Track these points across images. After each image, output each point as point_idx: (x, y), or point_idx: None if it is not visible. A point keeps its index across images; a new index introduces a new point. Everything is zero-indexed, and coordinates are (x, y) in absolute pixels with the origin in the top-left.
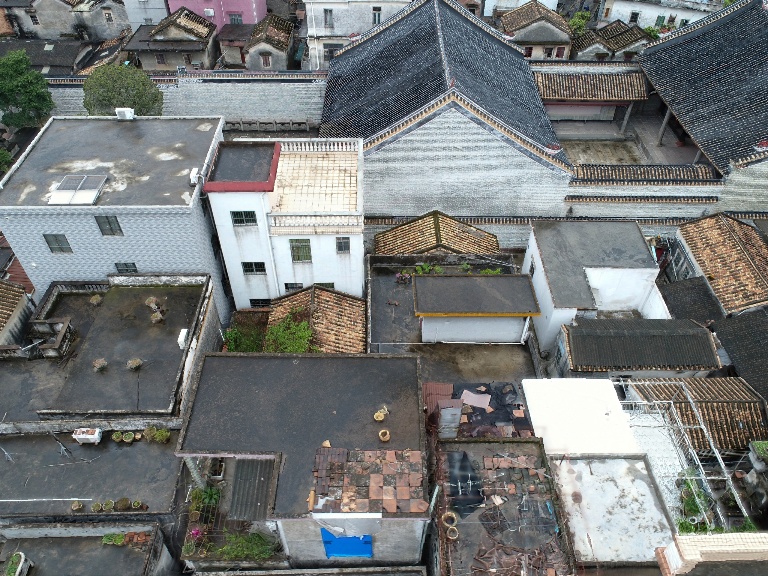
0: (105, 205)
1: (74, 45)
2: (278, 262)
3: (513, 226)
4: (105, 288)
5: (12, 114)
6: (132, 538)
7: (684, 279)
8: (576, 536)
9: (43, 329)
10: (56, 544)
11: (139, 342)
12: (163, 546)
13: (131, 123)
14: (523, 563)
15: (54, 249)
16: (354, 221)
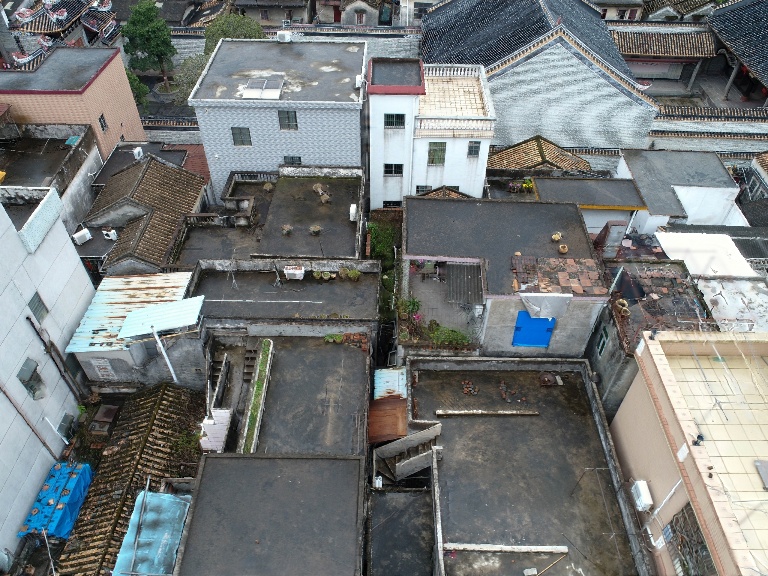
0: (289, 100)
1: (181, 3)
2: (415, 164)
3: (601, 157)
4: (274, 178)
5: (138, 59)
6: (348, 338)
7: (761, 199)
8: (717, 324)
9: (230, 206)
10: (288, 341)
11: (313, 216)
12: (371, 346)
13: (289, 45)
14: (697, 311)
15: (237, 142)
16: (488, 126)
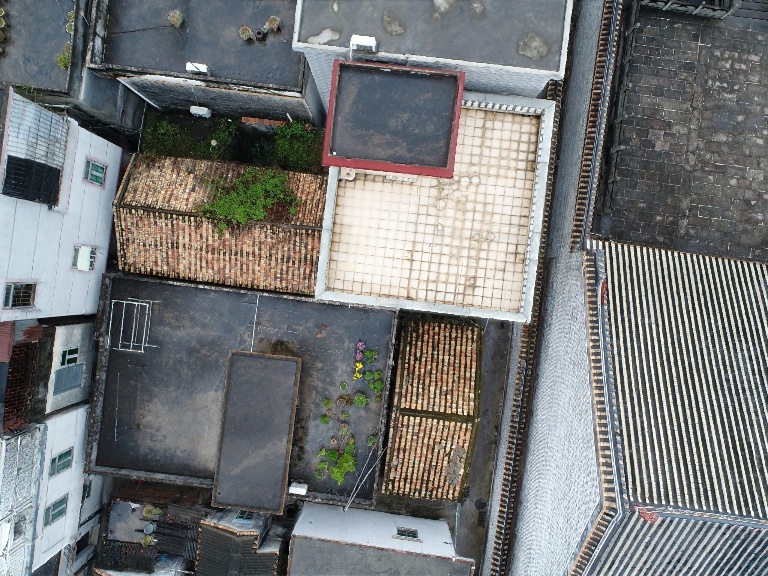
0: None
1: None
2: None
3: None
4: None
5: None
6: None
7: None
8: None
9: None
10: None
11: (216, 19)
12: None
13: None
14: None
15: None
16: None
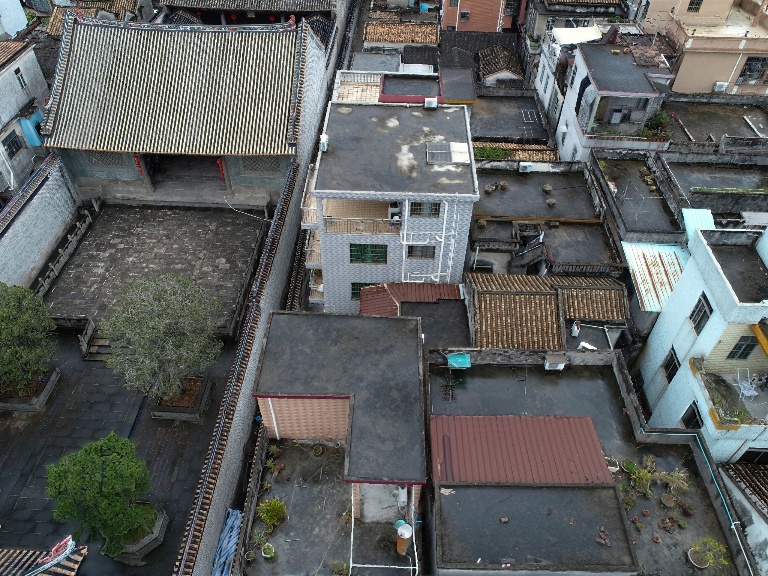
0: None
1: None
2: None
3: None
4: None
5: None
6: None
7: None
8: None
9: None
10: None
11: (524, 193)
12: None
13: (331, 146)
14: None
15: None
16: None
